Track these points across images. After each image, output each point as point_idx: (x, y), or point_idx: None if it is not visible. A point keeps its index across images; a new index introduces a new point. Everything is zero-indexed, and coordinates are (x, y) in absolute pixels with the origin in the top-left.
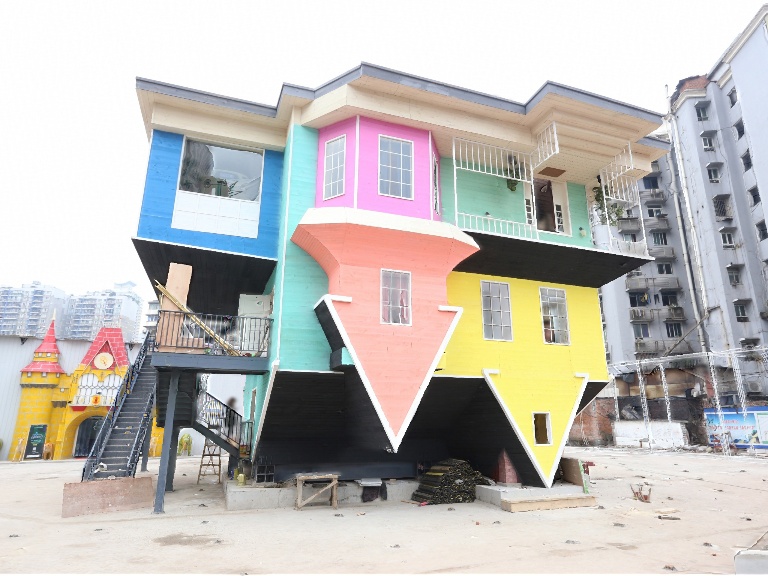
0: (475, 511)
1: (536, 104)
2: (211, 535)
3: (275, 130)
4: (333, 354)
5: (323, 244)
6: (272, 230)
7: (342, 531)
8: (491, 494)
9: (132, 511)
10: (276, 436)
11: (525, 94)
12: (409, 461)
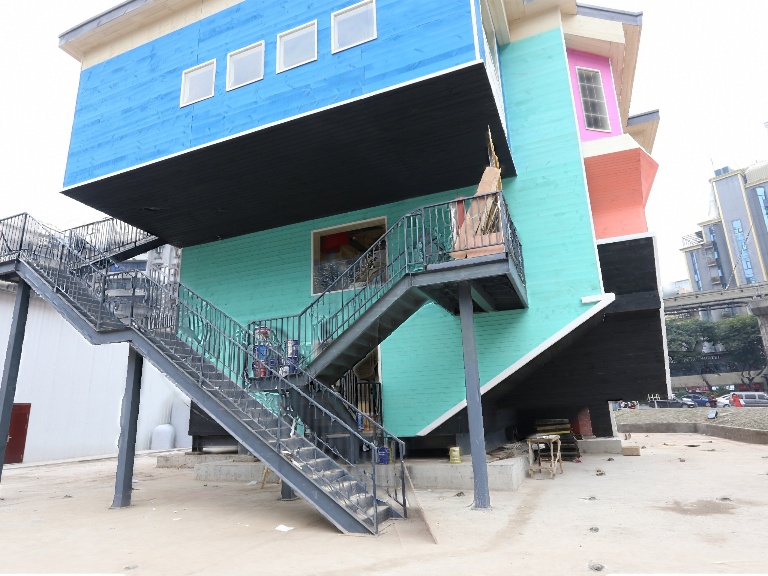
0: (624, 458)
1: (642, 122)
2: (679, 500)
3: (506, 16)
4: (618, 297)
5: (641, 178)
6: (508, 135)
7: (686, 478)
8: (605, 445)
9: (443, 515)
10: (489, 394)
11: (637, 110)
12: (507, 425)
